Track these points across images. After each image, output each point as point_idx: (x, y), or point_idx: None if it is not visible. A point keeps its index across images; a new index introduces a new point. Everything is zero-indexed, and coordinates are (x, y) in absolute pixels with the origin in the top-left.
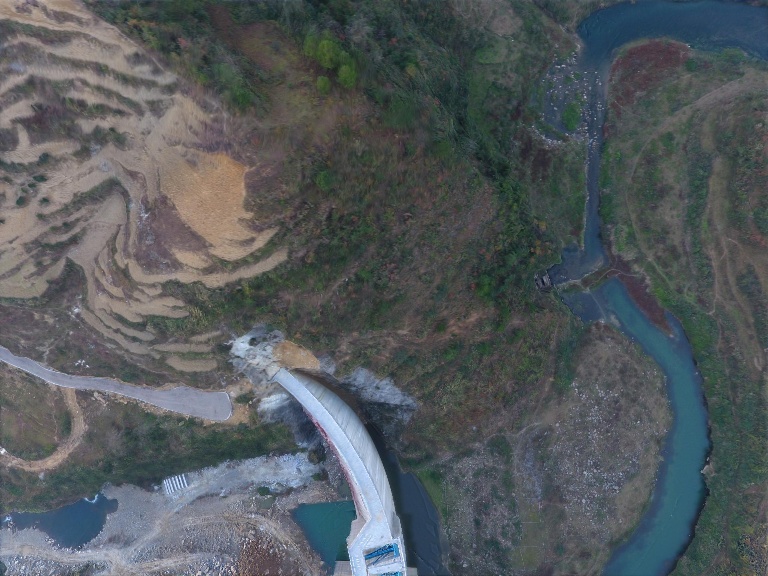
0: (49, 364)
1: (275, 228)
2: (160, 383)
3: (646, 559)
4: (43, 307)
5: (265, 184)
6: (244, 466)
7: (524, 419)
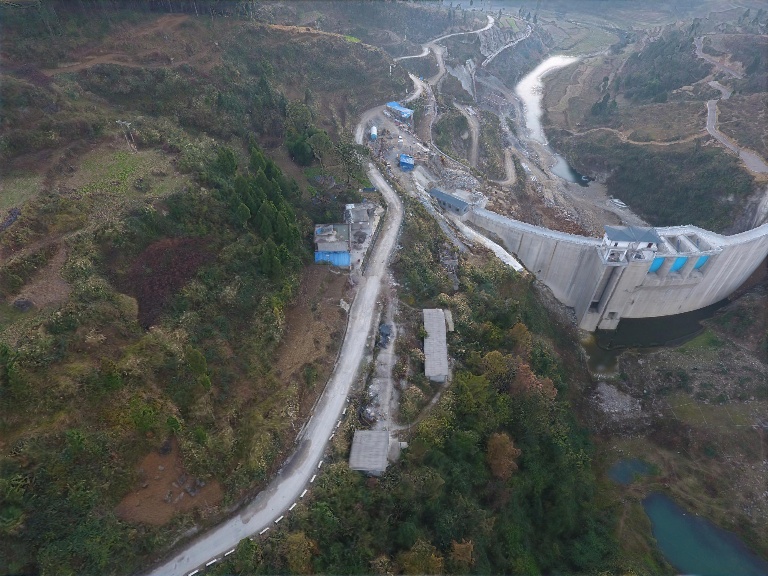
0: None
1: None
2: (754, 148)
3: None
4: None
5: None
6: None
7: None
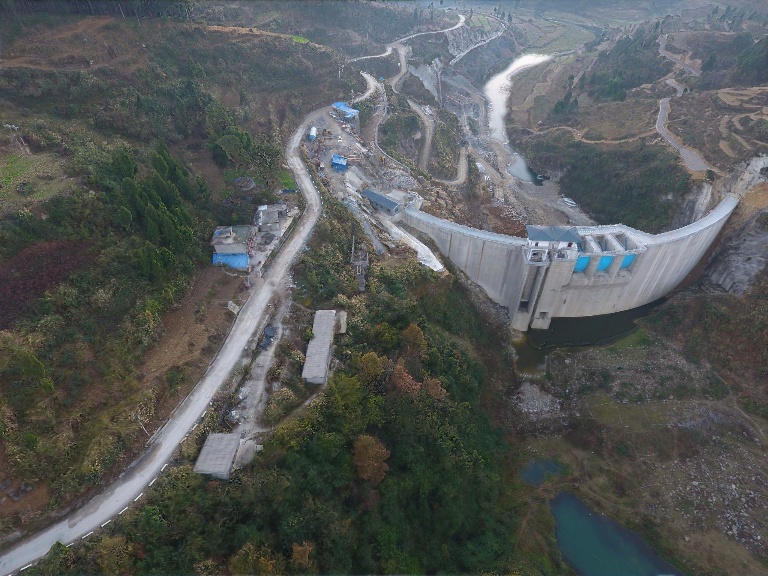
0: None
1: None
2: (696, 146)
3: None
4: (718, 109)
5: None
6: None
7: (762, 413)
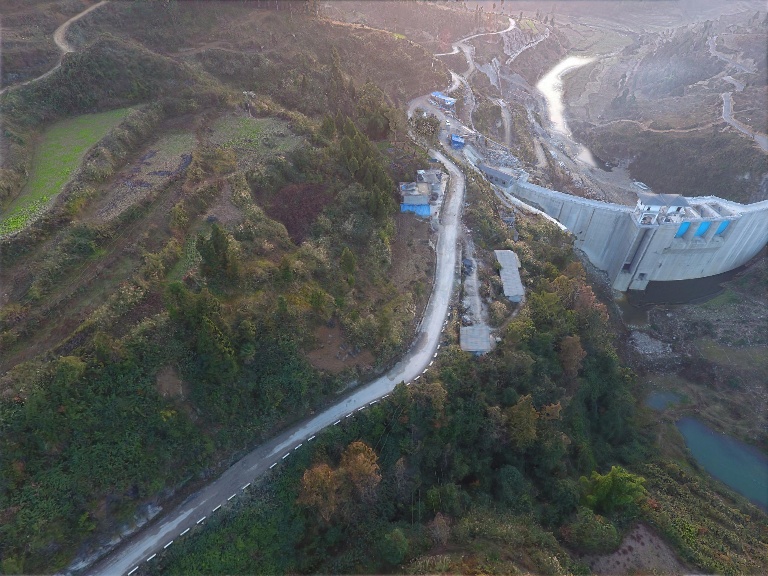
0: None
1: None
2: (767, 133)
3: (763, 490)
4: None
5: None
6: None
7: None
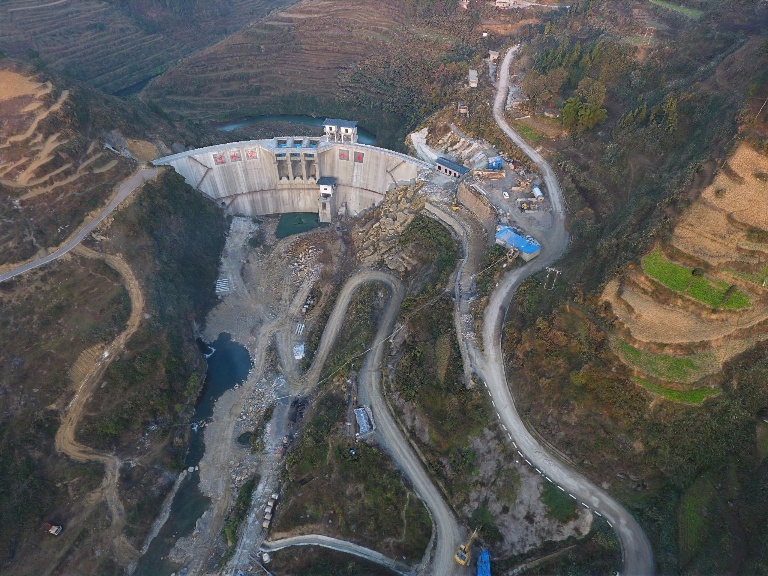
0: (45, 247)
1: (47, 81)
2: (110, 189)
3: None
4: None
5: (20, 68)
6: (229, 249)
7: None
